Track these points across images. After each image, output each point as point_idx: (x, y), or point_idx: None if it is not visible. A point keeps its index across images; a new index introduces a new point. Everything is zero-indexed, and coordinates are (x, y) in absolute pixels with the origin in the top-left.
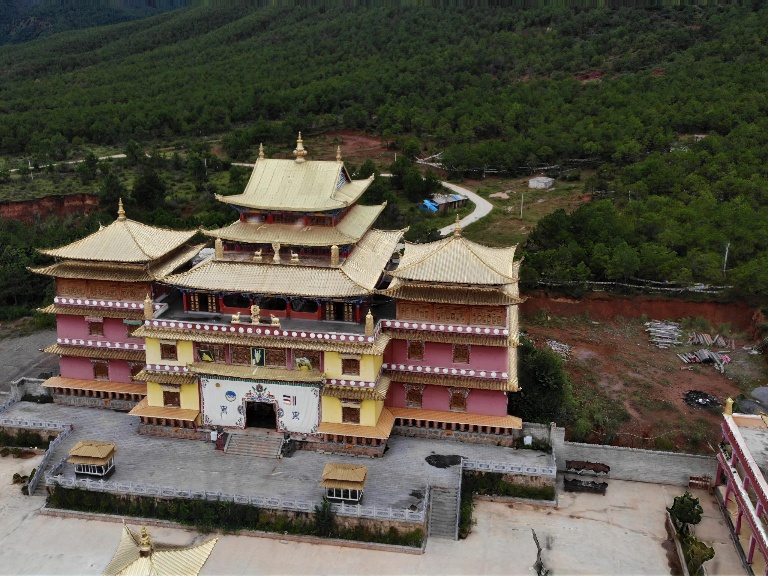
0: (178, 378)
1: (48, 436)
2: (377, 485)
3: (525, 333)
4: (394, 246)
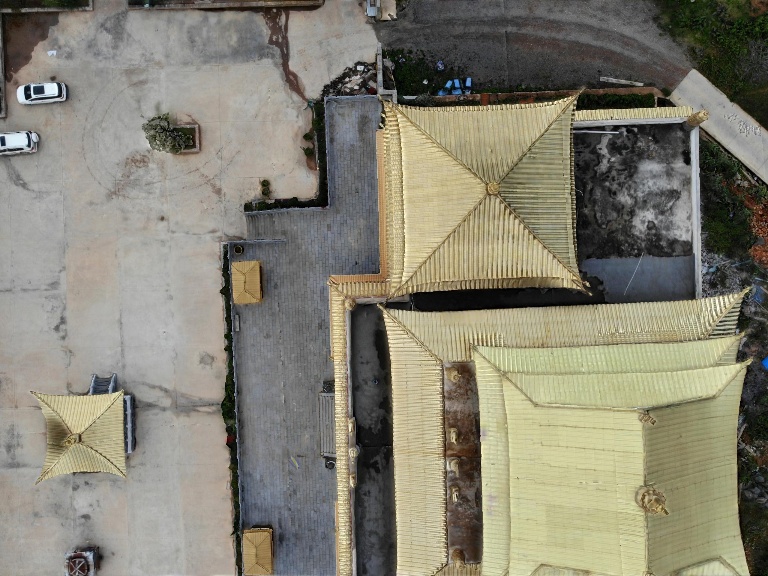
0: None
1: None
2: (295, 567)
3: None
4: None
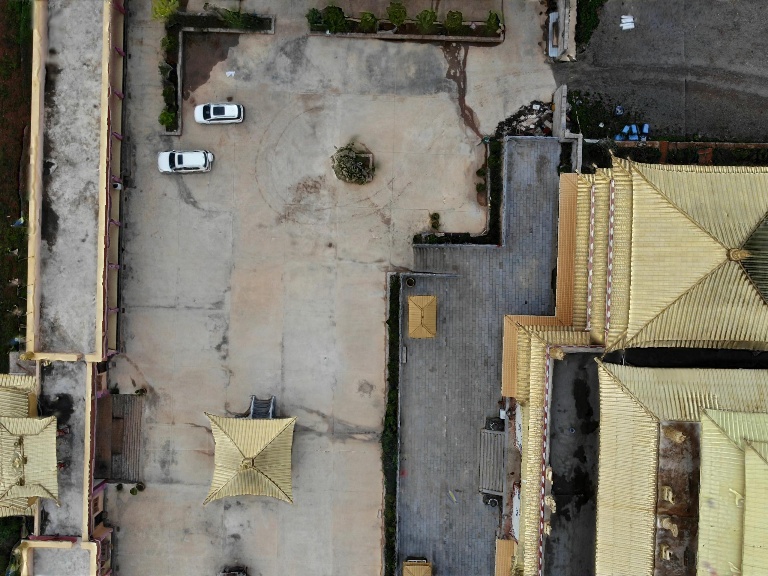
0: (524, 381)
1: (501, 214)
2: None
3: None
4: None
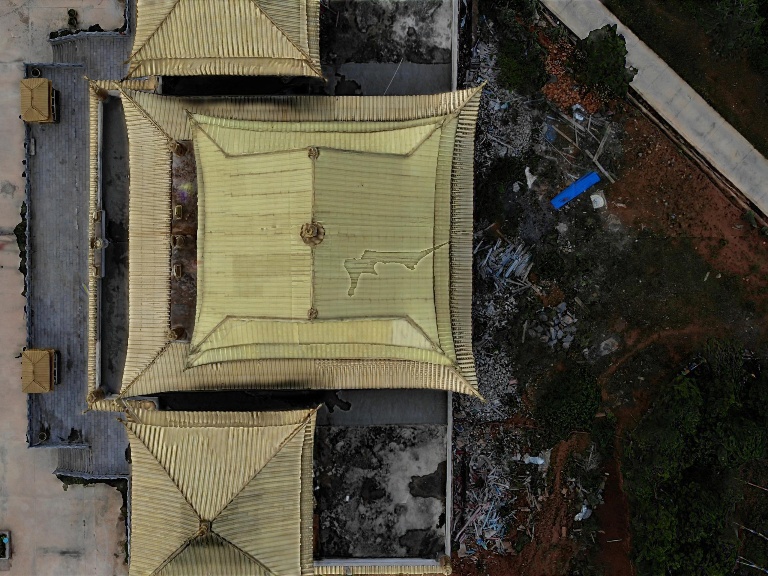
0: None
1: None
2: (82, 394)
3: (516, 549)
4: (404, 385)
